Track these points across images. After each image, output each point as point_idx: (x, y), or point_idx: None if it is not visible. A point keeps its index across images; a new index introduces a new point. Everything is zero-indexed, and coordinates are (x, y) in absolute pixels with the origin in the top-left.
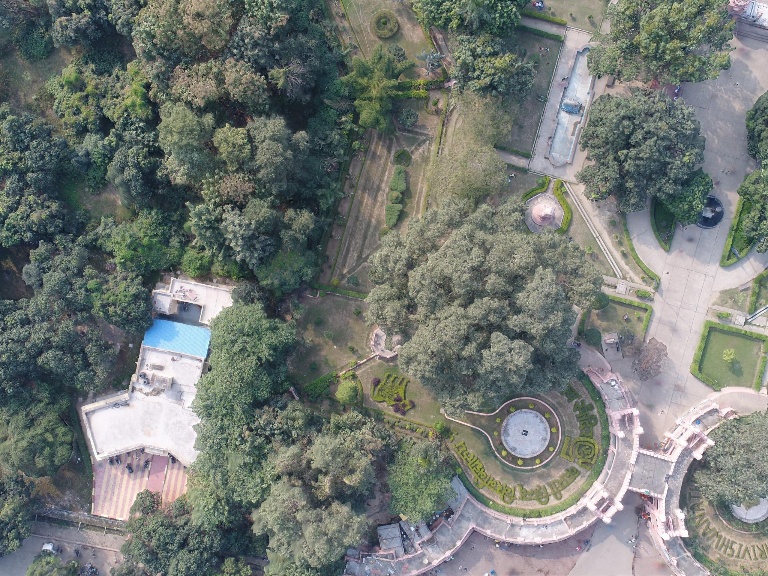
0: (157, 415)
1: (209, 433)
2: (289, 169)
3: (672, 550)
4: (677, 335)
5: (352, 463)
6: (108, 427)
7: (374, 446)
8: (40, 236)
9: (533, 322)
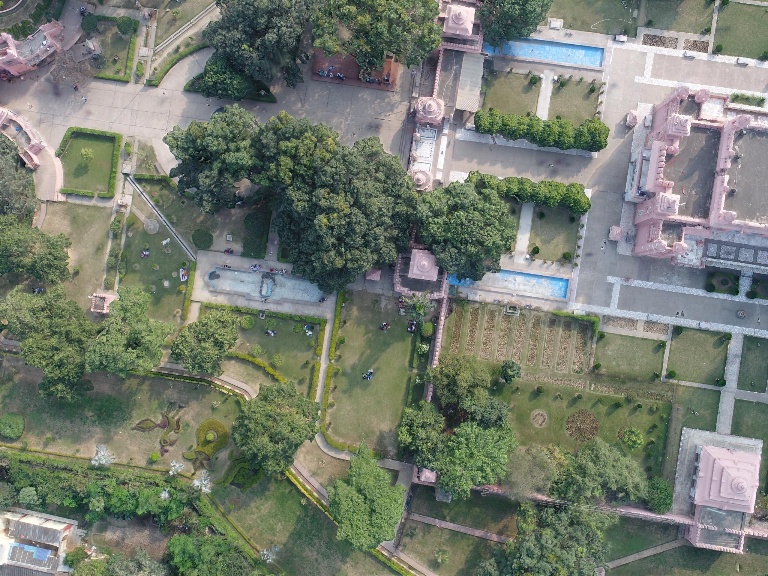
0: None
1: None
2: None
3: None
4: (106, 110)
5: None
6: None
7: None
8: None
9: None
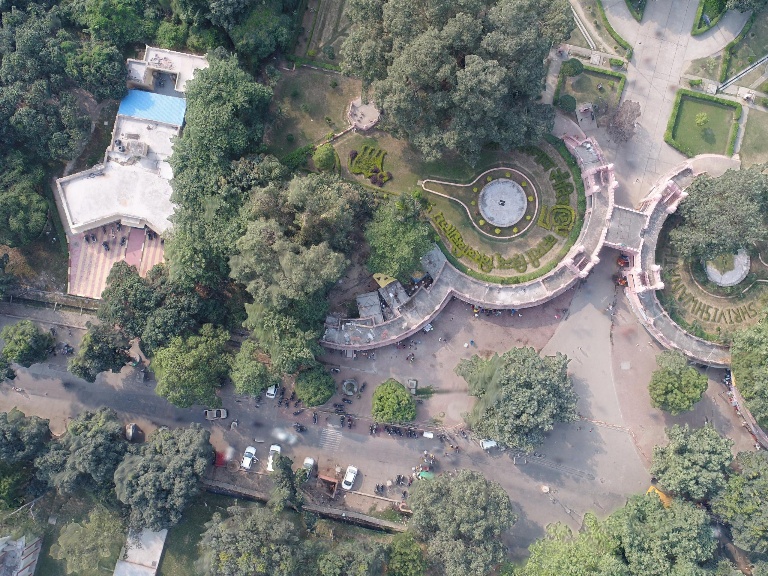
0: (133, 184)
1: (185, 182)
2: None
3: (649, 311)
4: (650, 104)
5: (329, 203)
6: (83, 197)
7: (351, 197)
8: (12, 5)
9: (506, 38)
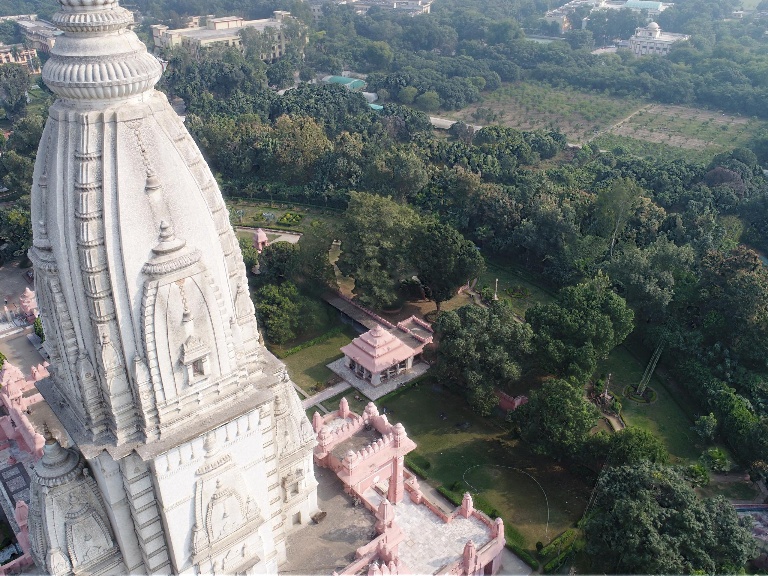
0: None
1: None
2: (198, 139)
3: None
4: None
5: None
6: None
7: None
8: None
9: None
